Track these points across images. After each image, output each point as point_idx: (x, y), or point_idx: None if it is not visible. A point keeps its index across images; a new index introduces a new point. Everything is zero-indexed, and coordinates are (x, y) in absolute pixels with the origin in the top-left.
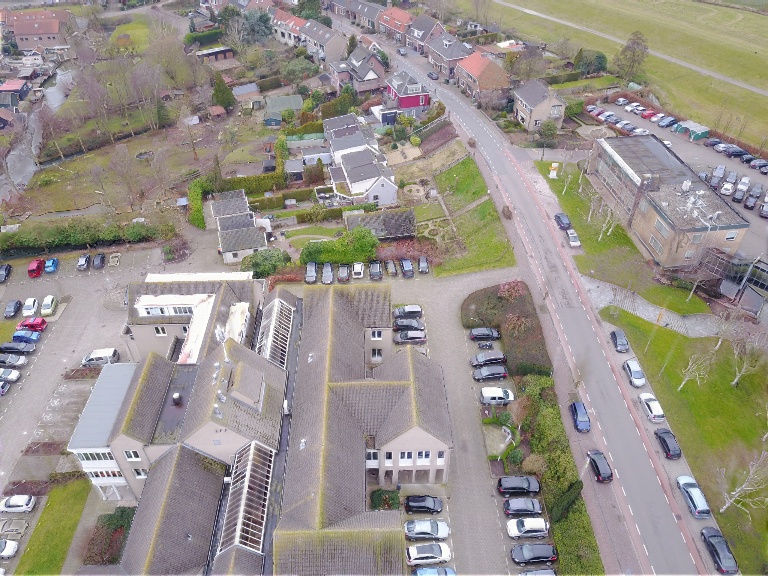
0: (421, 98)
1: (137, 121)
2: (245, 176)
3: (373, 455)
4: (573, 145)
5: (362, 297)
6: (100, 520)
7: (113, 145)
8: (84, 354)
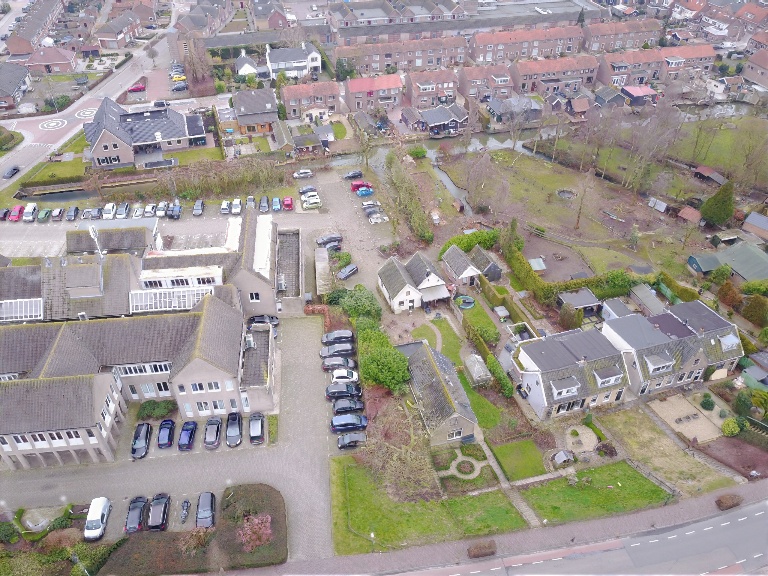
0: None
1: None
2: (540, 264)
3: None
4: None
5: None
6: None
7: (577, 172)
8: None
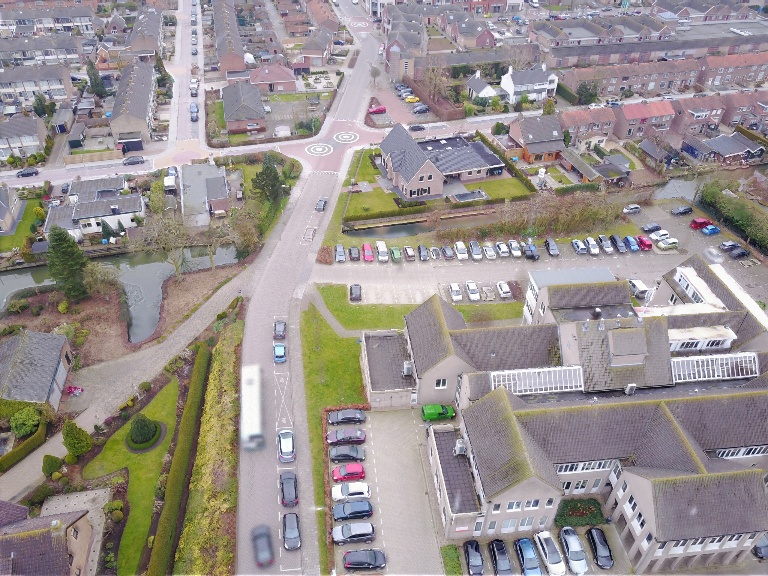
0: None
1: None
2: None
3: (618, 472)
4: None
5: None
6: None
7: None
8: None
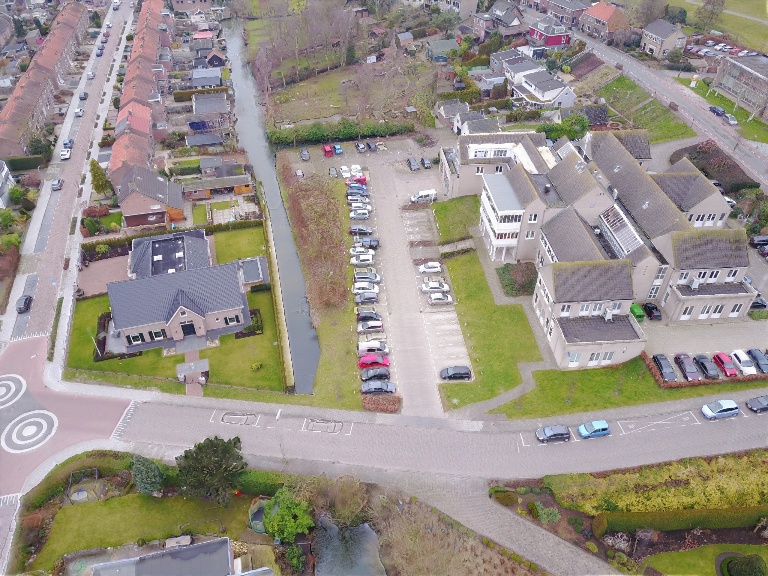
0: (563, 38)
1: (323, 61)
2: None
3: None
4: (694, 68)
5: (630, 138)
6: (499, 269)
7: (317, 77)
8: (406, 197)
